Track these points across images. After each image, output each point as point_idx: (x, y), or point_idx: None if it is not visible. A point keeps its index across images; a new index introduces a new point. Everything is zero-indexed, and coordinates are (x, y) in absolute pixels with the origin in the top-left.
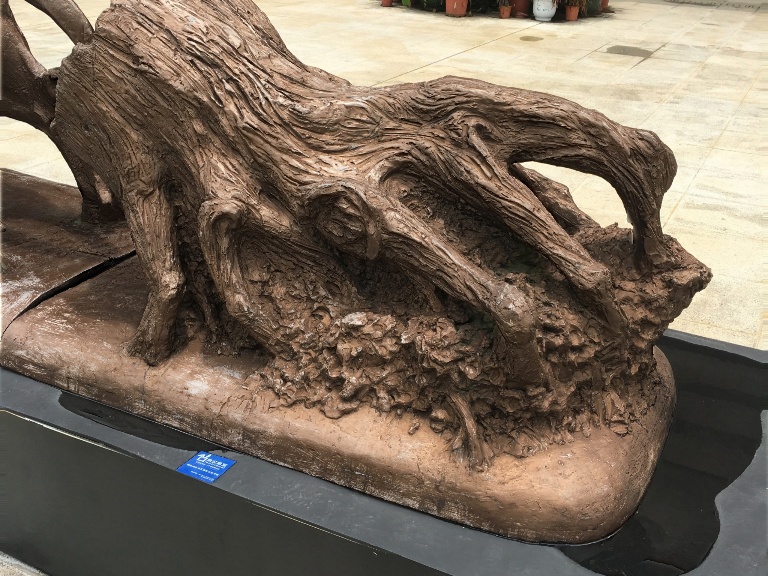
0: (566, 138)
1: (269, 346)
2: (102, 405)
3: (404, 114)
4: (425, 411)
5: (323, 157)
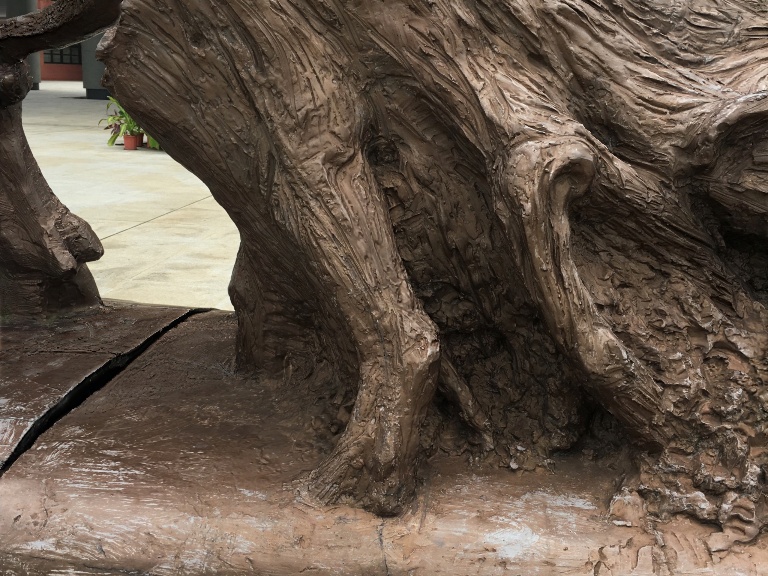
0: None
1: (652, 429)
2: None
3: None
4: None
5: (682, 69)
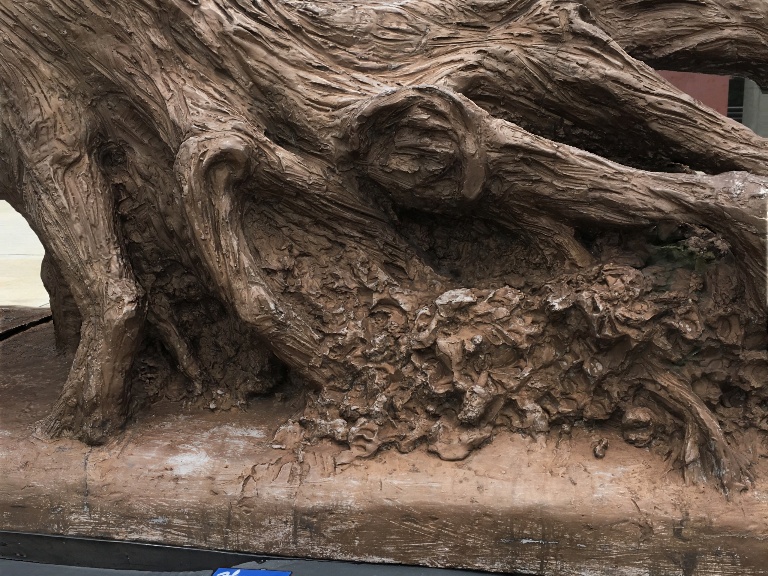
0: (701, 17)
1: (310, 370)
2: (3, 533)
3: (460, 17)
4: (607, 419)
5: (358, 75)
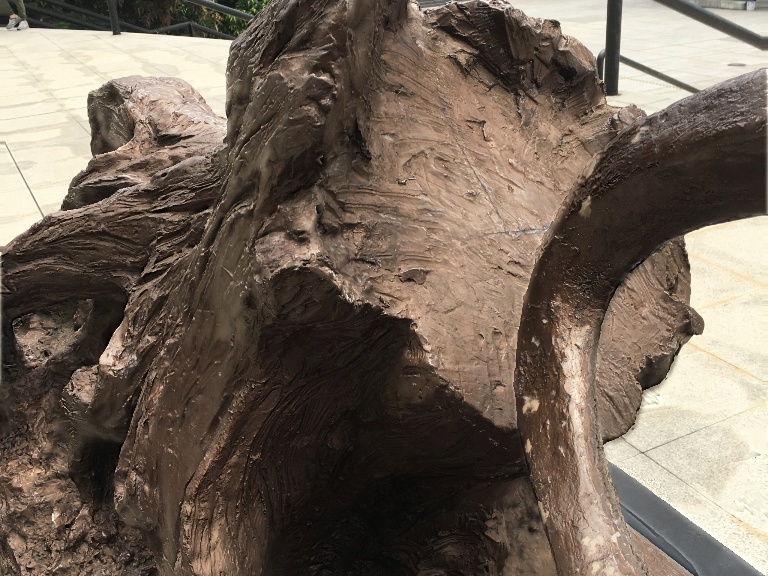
0: None
1: None
2: None
3: None
4: None
5: None
